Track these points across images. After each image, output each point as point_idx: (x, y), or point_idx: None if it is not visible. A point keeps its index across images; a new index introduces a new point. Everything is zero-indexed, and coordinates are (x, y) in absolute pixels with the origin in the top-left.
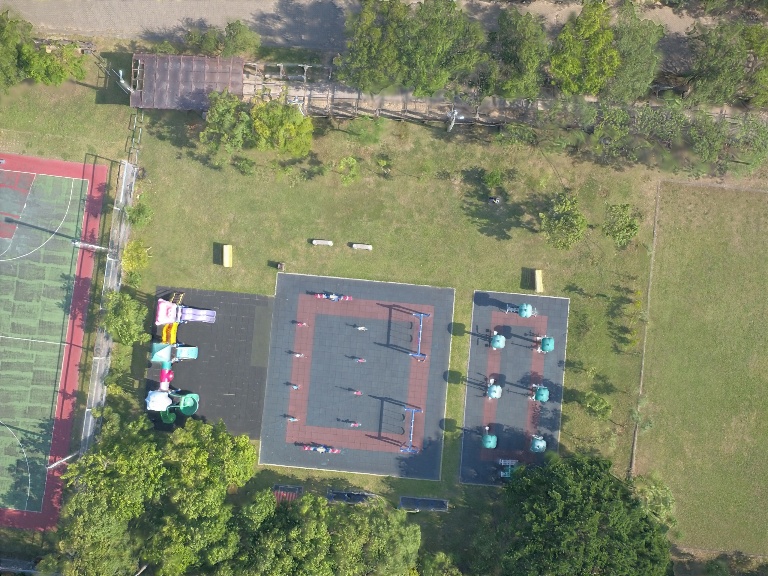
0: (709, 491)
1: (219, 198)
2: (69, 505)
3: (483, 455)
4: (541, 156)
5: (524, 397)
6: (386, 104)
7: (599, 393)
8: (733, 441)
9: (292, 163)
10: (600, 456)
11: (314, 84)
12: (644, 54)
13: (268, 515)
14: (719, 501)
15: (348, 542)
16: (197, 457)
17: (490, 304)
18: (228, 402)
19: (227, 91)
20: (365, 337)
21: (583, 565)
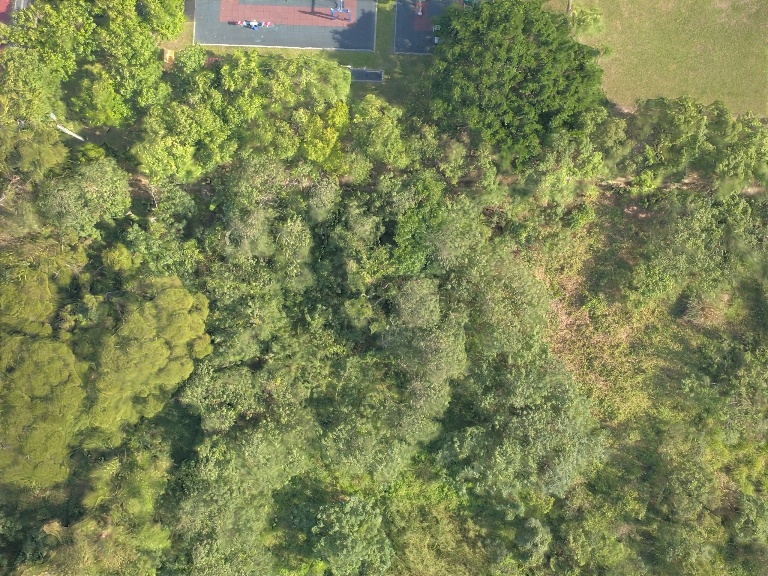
0: (647, 49)
1: None
2: (0, 56)
3: (417, 25)
4: None
5: None
6: None
7: None
8: None
9: None
10: None
11: None
12: None
13: (198, 66)
14: (657, 58)
15: (275, 71)
16: (124, 0)
17: None
18: None
19: None
20: None
21: (507, 59)
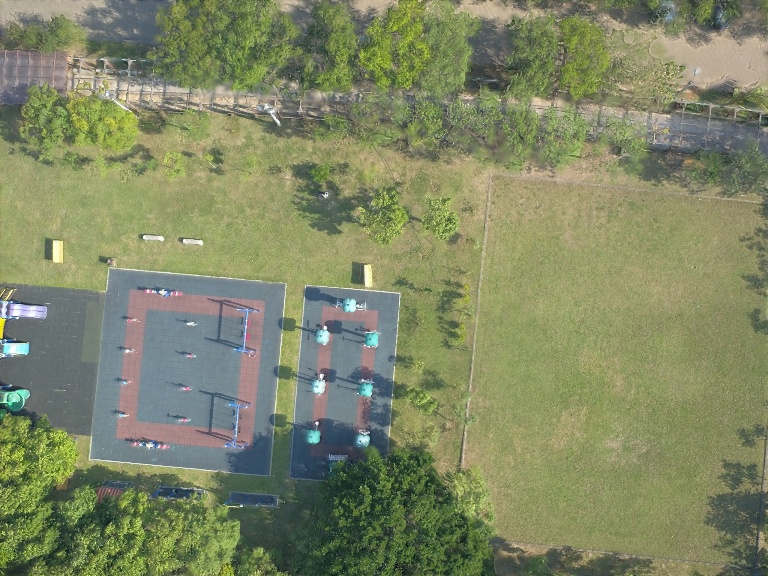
0: (538, 485)
1: (51, 193)
2: None
3: (313, 450)
4: (372, 150)
5: (354, 392)
6: (217, 98)
7: (429, 388)
8: (563, 435)
9: (123, 158)
10: (430, 451)
11: (146, 78)
12: (455, 47)
13: (87, 510)
14: (548, 495)
15: (160, 537)
16: (12, 453)
17: (321, 299)
18: (59, 398)
19: (48, 86)
20: (196, 332)
21: (385, 560)
